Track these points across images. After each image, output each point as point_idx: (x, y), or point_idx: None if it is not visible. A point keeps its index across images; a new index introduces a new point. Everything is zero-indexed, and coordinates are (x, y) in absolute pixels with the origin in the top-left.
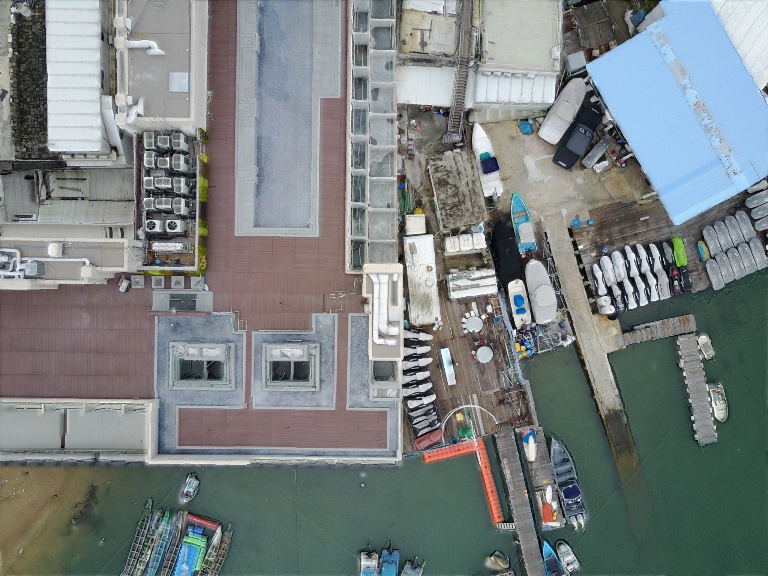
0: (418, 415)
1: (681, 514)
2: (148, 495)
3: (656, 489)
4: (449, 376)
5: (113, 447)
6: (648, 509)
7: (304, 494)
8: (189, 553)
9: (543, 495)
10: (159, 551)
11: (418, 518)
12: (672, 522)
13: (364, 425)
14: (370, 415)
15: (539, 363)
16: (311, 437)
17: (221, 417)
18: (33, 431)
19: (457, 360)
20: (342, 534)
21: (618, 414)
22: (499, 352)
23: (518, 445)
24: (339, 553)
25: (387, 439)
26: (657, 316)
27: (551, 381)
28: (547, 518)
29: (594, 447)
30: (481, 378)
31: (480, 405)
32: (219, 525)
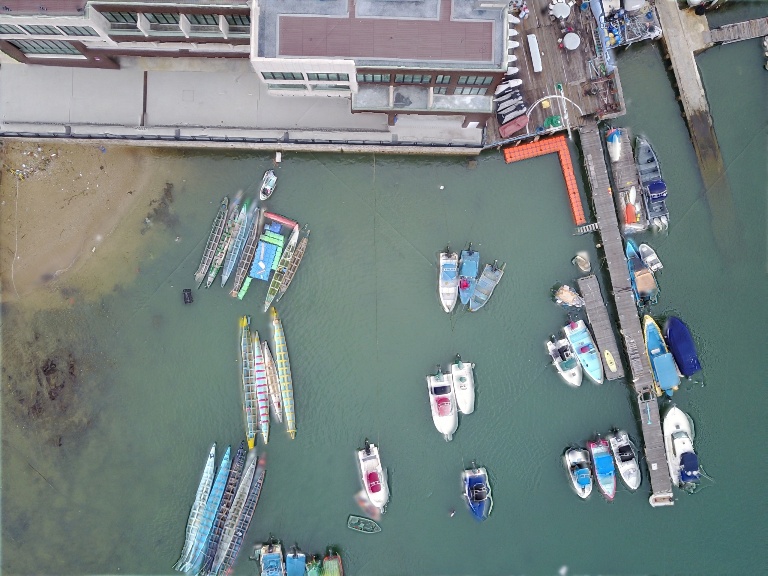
0: (504, 99)
1: (765, 223)
2: (224, 194)
3: (740, 198)
4: (535, 62)
5: (194, 123)
6: (732, 217)
7: (382, 196)
8: (265, 252)
9: (626, 196)
10: (235, 250)
11: (498, 223)
12: (756, 231)
13: (468, 36)
14: (475, 26)
15: (623, 66)
16: (414, 48)
17: (322, 26)
18: (112, 109)
19: (543, 49)
20: (420, 239)
21: (703, 115)
22: (585, 42)
23: (602, 142)
24: (416, 261)
25: (492, 51)
26: (743, 19)
27: (635, 85)
28: (631, 218)
29: (678, 152)
30: (567, 68)
31: (566, 96)
32: (296, 224)
